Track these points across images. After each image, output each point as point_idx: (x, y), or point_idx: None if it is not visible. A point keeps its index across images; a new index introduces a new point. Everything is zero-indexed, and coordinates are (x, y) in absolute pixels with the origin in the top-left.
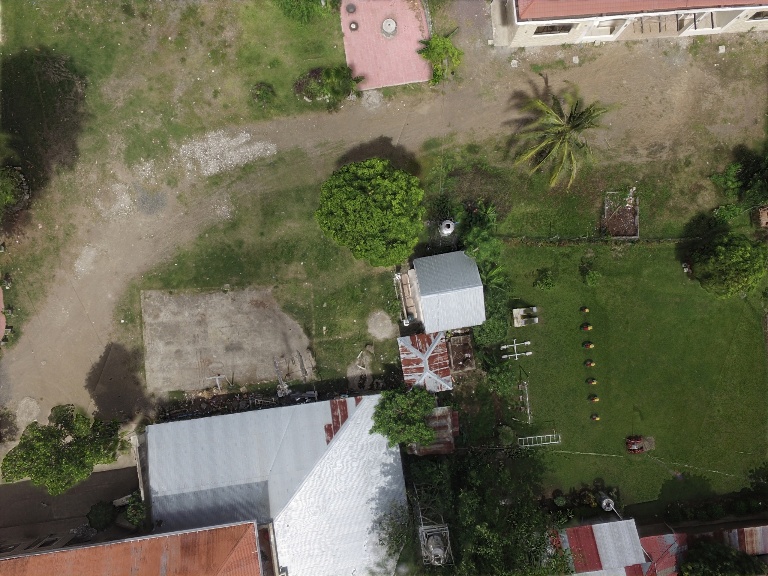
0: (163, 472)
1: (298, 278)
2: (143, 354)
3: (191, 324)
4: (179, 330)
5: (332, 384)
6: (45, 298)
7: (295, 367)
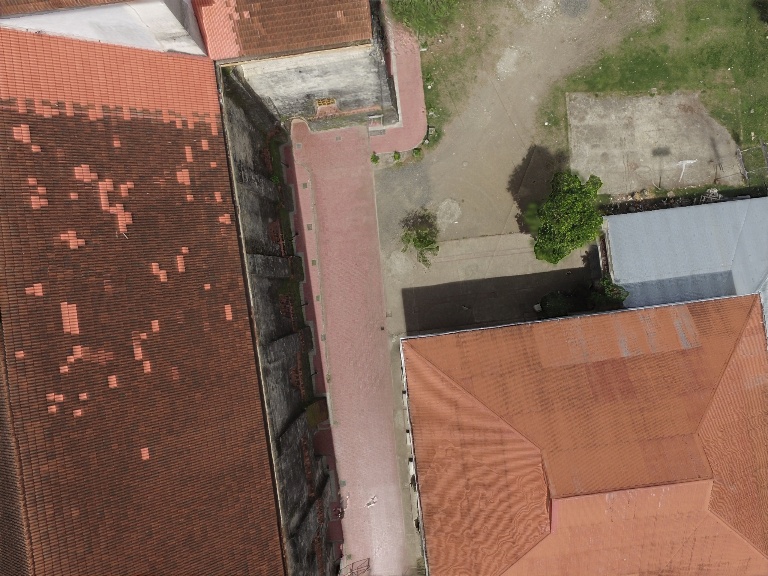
0: (622, 261)
1: (726, 83)
2: (568, 156)
3: (618, 127)
4: (606, 133)
5: (760, 190)
6: (467, 99)
7: (722, 173)
